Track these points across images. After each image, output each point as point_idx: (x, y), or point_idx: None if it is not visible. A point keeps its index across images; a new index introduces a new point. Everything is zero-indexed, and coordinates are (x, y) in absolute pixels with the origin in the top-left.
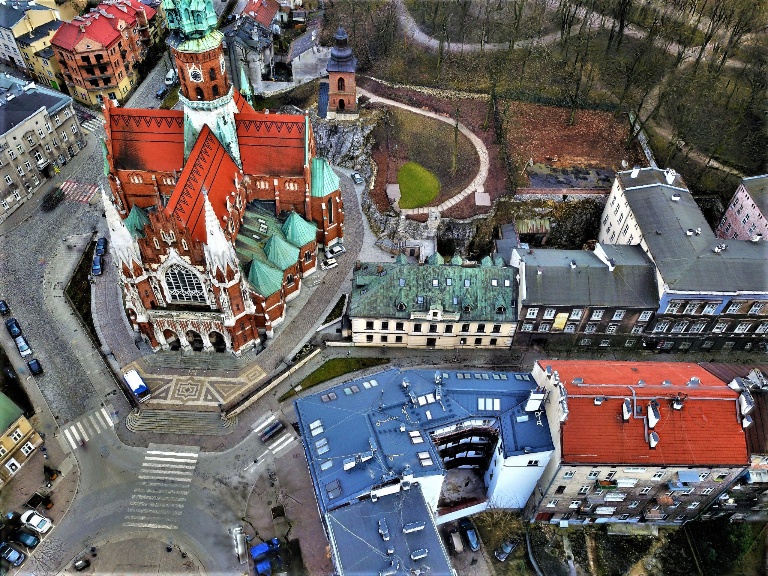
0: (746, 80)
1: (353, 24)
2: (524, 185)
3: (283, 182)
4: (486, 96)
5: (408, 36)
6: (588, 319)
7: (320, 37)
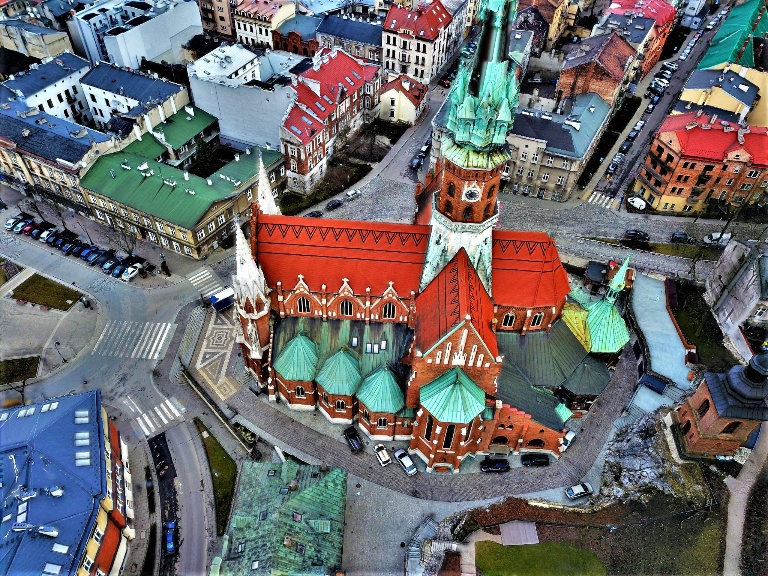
0: None
1: None
2: None
3: None
4: None
5: None
6: None
7: None
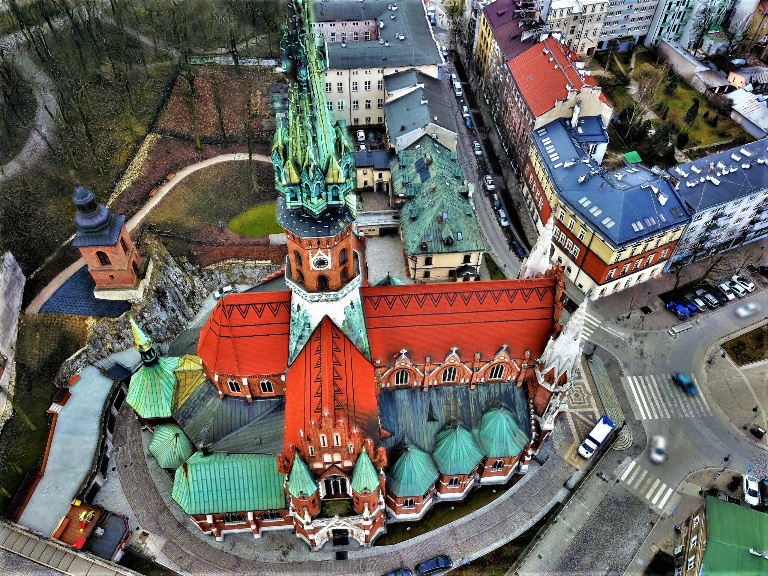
0: None
1: None
2: None
3: None
4: (150, 137)
5: None
6: None
7: None
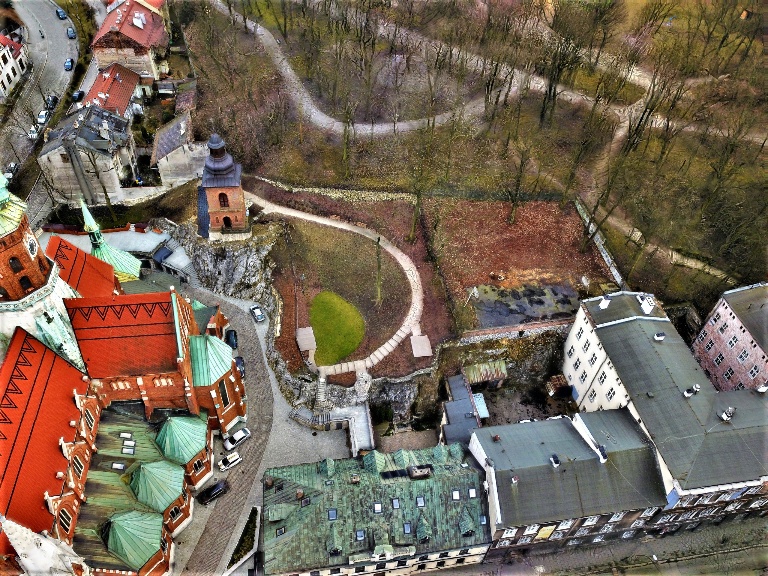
0: (693, 148)
1: (232, 114)
2: (470, 322)
3: (150, 379)
4: (408, 196)
5: (303, 117)
6: (579, 525)
7: (193, 120)
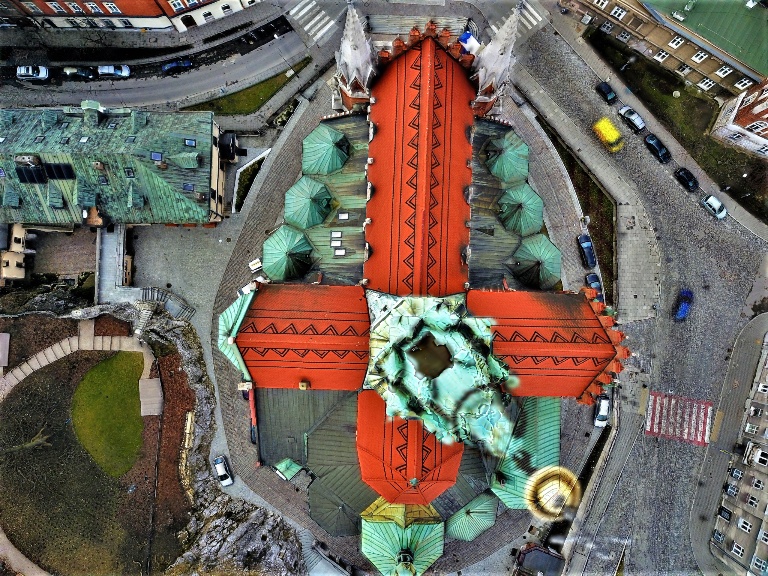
0: None
1: None
2: None
3: None
4: None
5: None
6: None
7: None
